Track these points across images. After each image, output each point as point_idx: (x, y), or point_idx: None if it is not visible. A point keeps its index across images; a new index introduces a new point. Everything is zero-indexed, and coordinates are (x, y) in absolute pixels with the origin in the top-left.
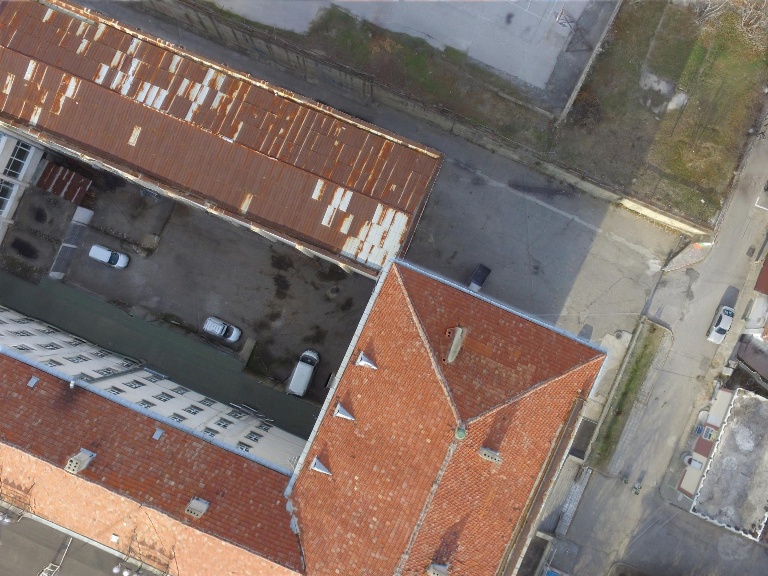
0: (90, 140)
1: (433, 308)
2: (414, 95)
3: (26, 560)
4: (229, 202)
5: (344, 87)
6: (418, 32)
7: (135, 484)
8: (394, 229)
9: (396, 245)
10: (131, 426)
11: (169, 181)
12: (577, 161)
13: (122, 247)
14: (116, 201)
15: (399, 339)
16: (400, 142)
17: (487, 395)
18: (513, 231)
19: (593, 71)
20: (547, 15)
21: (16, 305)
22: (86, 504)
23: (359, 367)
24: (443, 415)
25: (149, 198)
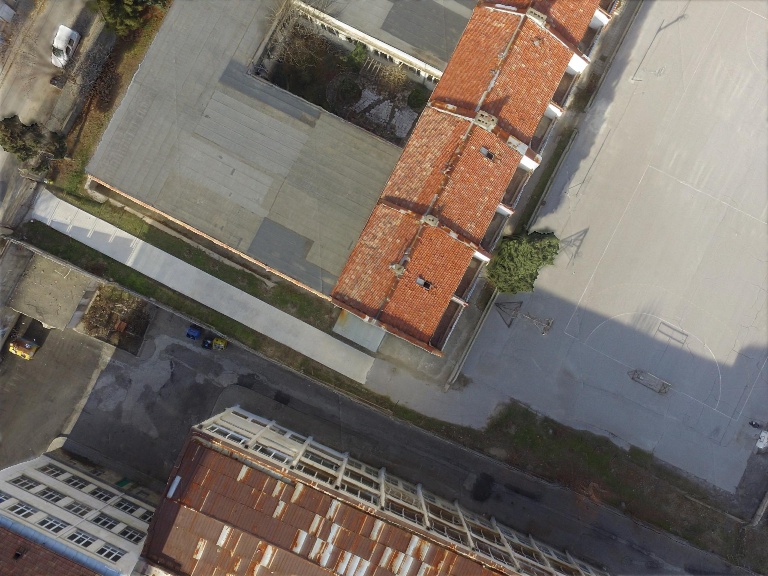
0: None
1: None
2: None
3: None
4: None
5: None
6: (601, 430)
7: None
8: None
9: None
10: None
11: None
12: (766, 564)
13: None
14: None
15: None
16: None
17: None
18: None
19: None
20: (737, 415)
21: None
22: None
23: None
24: None
25: None
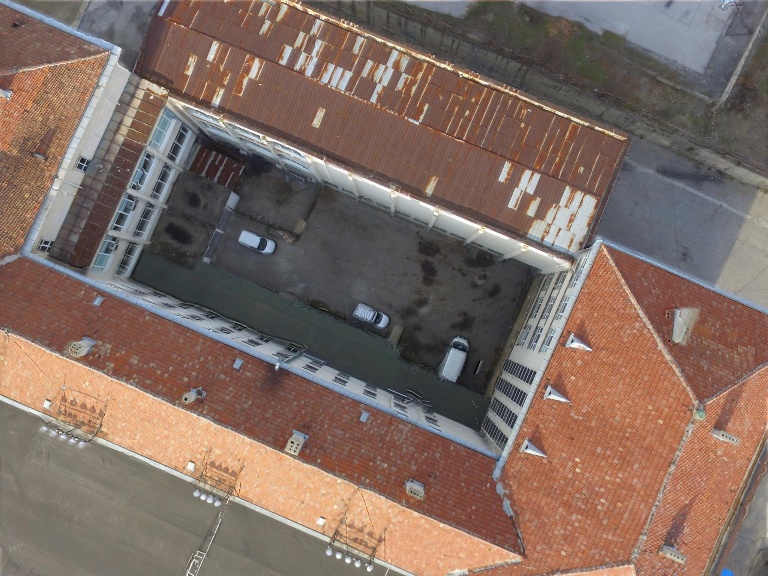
0: (273, 122)
1: (648, 289)
2: (576, 79)
3: (173, 547)
4: (414, 185)
5: (493, 72)
6: (576, 16)
7: (350, 466)
8: (582, 212)
9: (584, 228)
10: (337, 408)
11: (353, 163)
12: (733, 146)
13: (268, 233)
14: (261, 187)
15: (616, 320)
16: (586, 124)
17: (716, 376)
18: (661, 217)
19: (749, 56)
20: None
21: (172, 290)
22: (297, 486)
23: (570, 349)
24: (677, 396)
25: (295, 184)
